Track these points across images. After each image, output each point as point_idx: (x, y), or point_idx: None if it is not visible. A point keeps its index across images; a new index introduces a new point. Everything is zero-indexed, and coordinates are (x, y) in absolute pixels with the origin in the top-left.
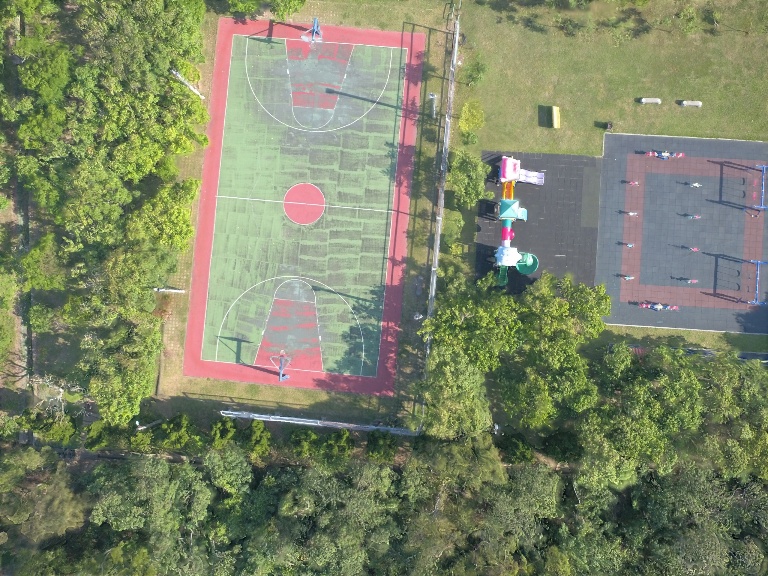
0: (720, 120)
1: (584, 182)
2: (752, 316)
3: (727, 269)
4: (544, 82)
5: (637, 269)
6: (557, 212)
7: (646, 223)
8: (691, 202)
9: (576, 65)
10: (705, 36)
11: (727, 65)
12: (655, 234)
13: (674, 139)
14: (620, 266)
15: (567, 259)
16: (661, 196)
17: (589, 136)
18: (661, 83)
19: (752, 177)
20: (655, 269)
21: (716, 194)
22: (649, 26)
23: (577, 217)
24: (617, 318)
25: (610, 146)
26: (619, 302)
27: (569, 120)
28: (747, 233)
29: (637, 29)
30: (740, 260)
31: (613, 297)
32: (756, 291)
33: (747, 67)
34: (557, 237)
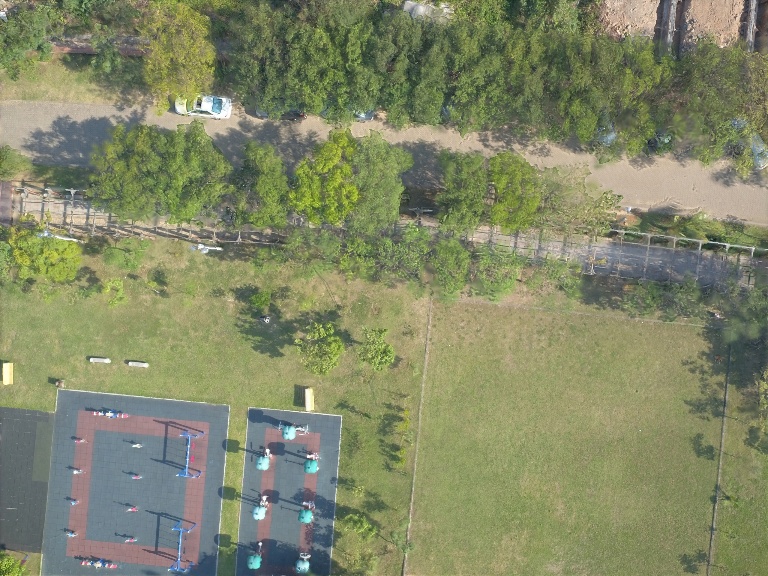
0: (166, 381)
1: (37, 437)
2: (190, 575)
3: (168, 528)
4: (3, 336)
5: (83, 525)
6: (10, 465)
7: (93, 480)
8: (136, 461)
9: (33, 321)
10: (155, 297)
11: (175, 327)
12: (101, 491)
13: (123, 398)
14: (67, 521)
15: (18, 512)
16: (108, 454)
17: (43, 392)
18: (112, 342)
19: (195, 438)
20: (100, 525)
21: (160, 454)
22: (103, 285)
23: (29, 471)
24: (62, 572)
25: (63, 402)
26: (65, 556)
27: (24, 375)
28: (188, 493)
29: (90, 288)
30: (180, 520)
31: (60, 551)
32: (178, 558)
33: (194, 329)
34: (9, 490)
